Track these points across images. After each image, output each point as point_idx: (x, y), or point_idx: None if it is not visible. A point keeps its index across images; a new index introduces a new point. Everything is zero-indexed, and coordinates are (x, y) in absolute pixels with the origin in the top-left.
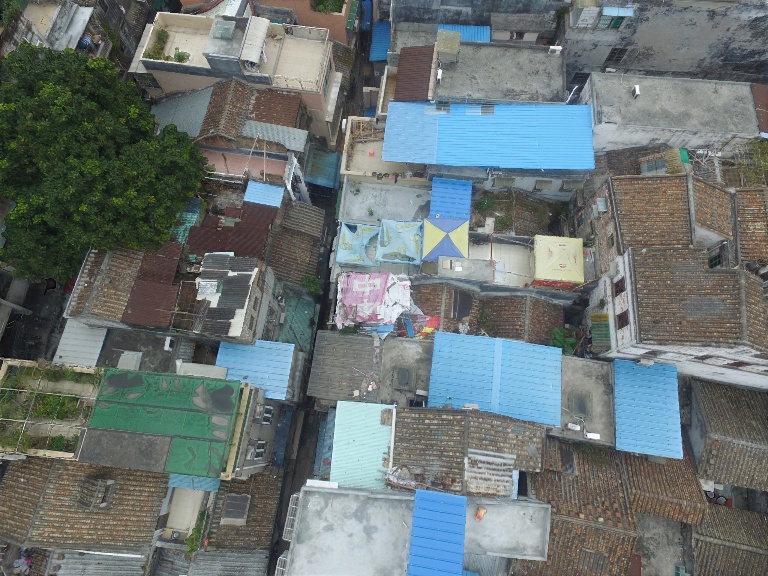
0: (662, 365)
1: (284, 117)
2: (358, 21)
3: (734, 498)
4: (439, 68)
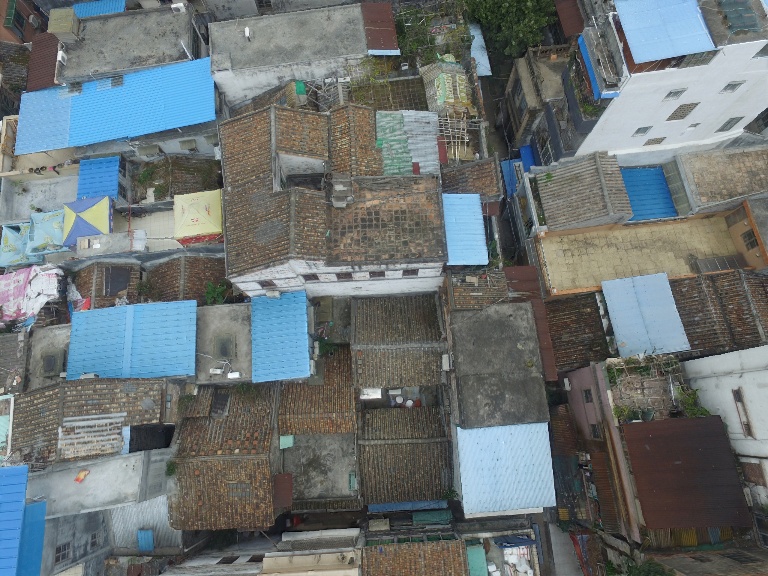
0: (292, 293)
1: None
2: (36, 16)
3: (425, 398)
4: (62, 49)
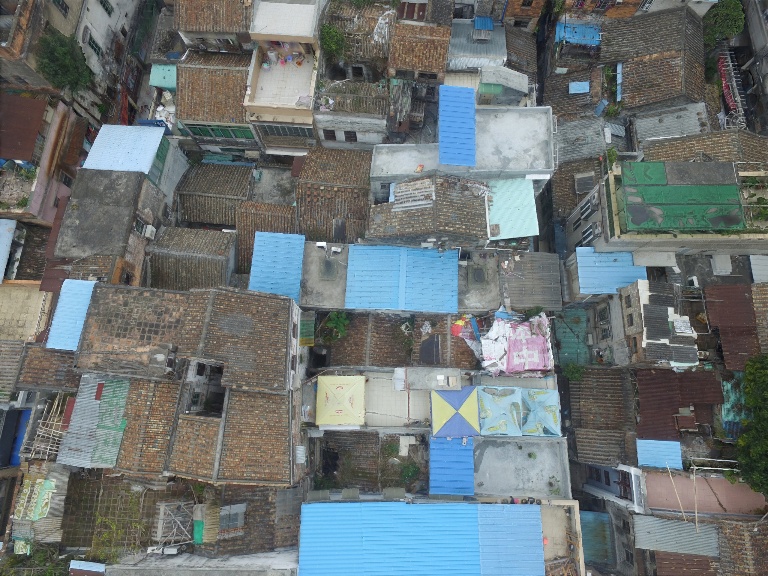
0: None
1: (673, 567)
2: None
3: None
4: None
